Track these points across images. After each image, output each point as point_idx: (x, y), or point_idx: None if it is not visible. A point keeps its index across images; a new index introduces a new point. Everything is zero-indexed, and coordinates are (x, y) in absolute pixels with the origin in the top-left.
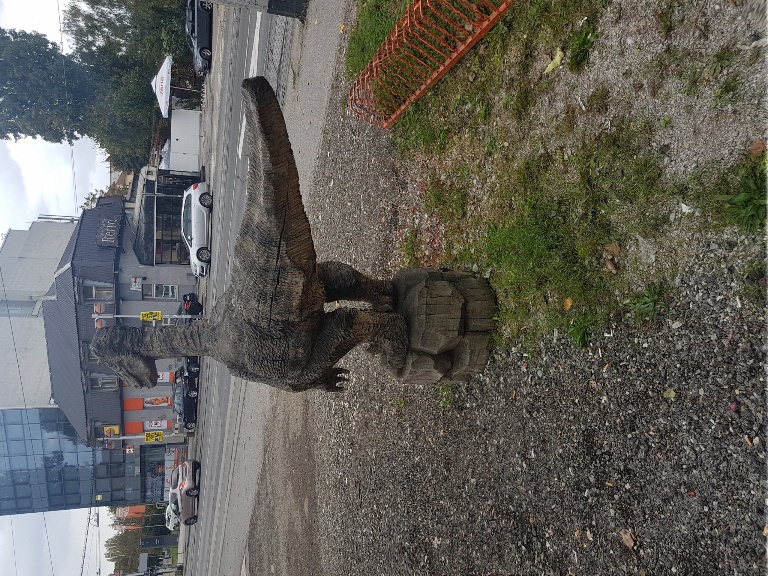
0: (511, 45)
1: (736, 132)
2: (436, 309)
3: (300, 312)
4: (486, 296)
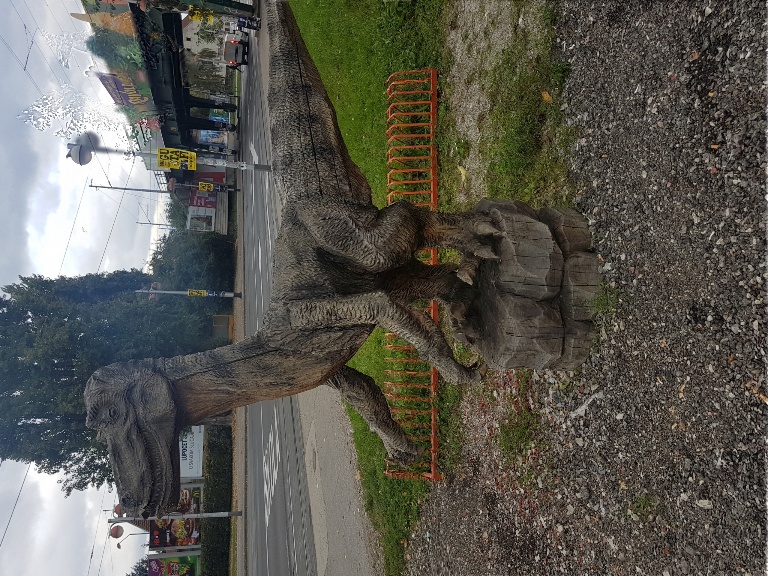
0: None
1: (505, 7)
2: None
3: (345, 171)
4: None
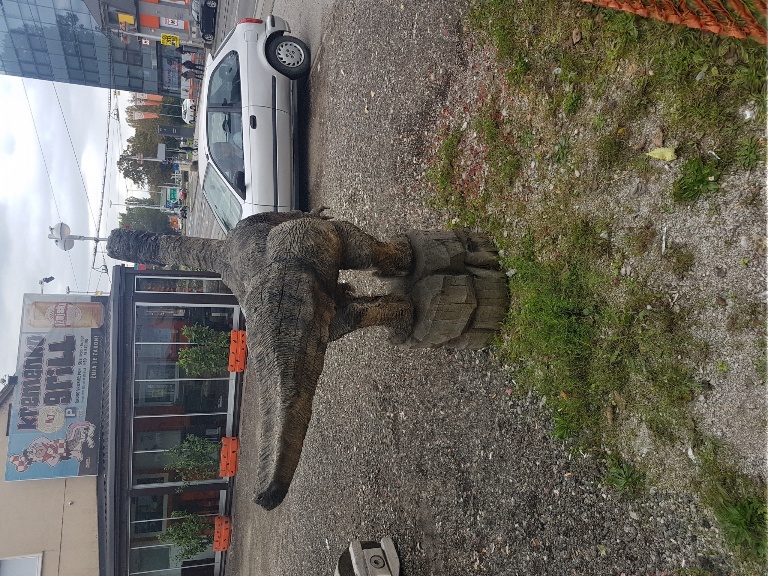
0: (632, 60)
1: None
2: (445, 315)
3: None
4: (500, 300)
